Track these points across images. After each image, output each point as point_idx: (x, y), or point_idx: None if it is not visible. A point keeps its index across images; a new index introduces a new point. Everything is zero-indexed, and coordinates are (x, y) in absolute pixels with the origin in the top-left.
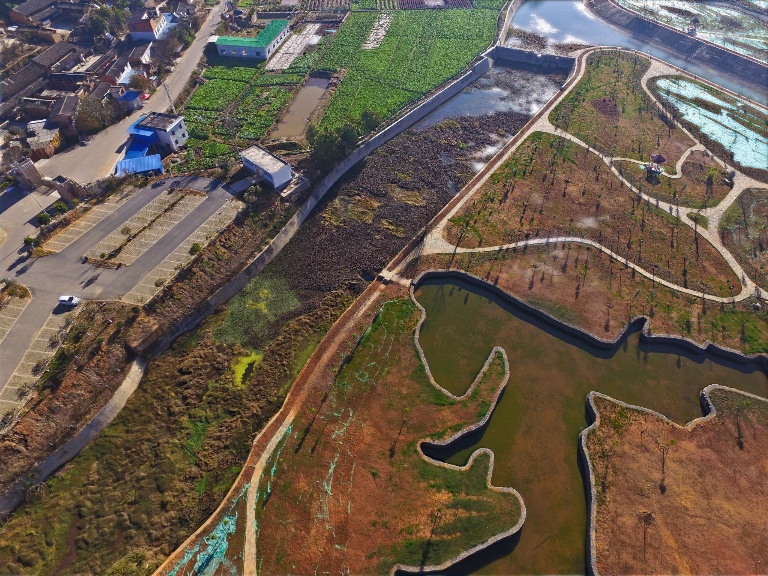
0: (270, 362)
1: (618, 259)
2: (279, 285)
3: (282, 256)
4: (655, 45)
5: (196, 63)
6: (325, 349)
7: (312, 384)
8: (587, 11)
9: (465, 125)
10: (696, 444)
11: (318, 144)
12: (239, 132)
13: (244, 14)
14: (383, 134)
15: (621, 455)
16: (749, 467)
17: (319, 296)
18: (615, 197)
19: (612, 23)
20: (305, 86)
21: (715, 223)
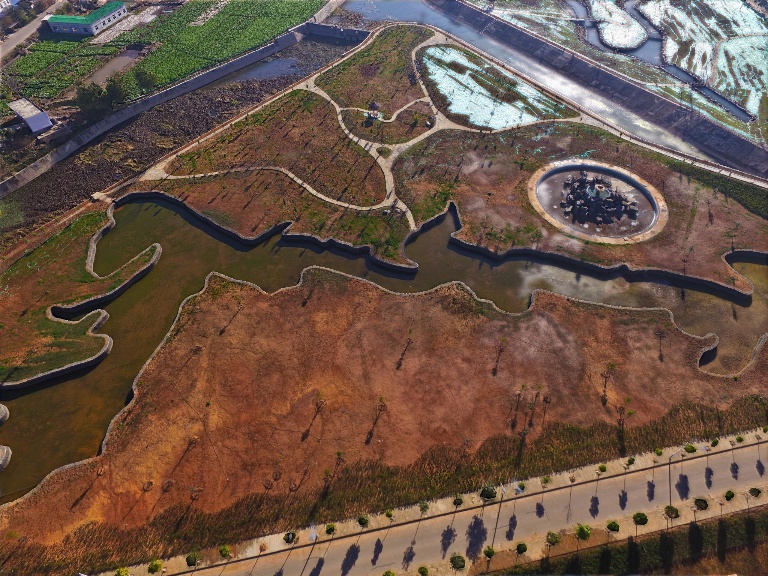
0: None
1: (297, 181)
2: (13, 207)
3: (27, 186)
4: (458, 22)
5: (25, 38)
6: (15, 248)
7: None
8: None
9: (246, 86)
10: (269, 304)
11: (79, 96)
12: (37, 93)
13: None
14: (164, 93)
15: (205, 312)
16: (299, 317)
17: (42, 215)
18: (326, 137)
19: (431, 4)
20: (118, 56)
21: (396, 154)
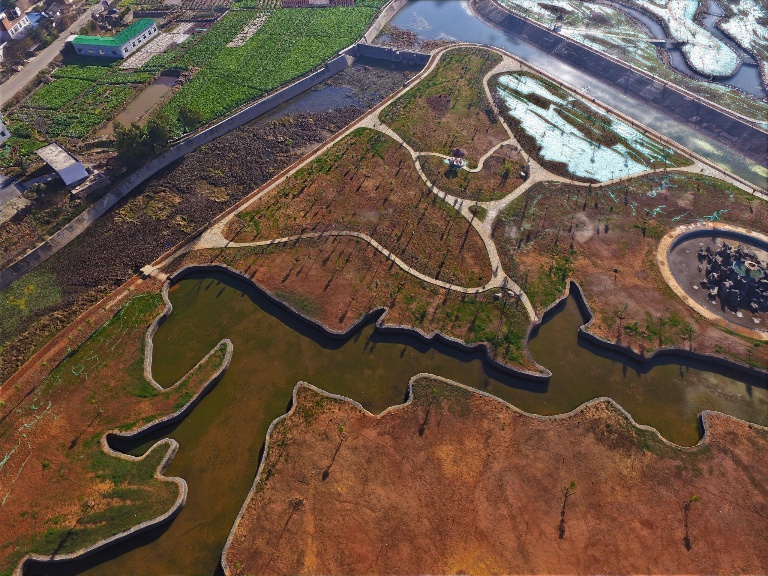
0: (6, 357)
1: (382, 252)
2: (47, 281)
3: (62, 253)
4: (522, 42)
5: (48, 62)
6: (55, 344)
7: (27, 378)
8: (470, 9)
9: (299, 122)
10: (378, 431)
11: (118, 141)
12: (65, 130)
13: (118, 13)
14: (210, 131)
15: (300, 443)
16: (419, 453)
17: (82, 292)
18: (406, 191)
19: (488, 20)
20: (152, 84)
21: (493, 215)
